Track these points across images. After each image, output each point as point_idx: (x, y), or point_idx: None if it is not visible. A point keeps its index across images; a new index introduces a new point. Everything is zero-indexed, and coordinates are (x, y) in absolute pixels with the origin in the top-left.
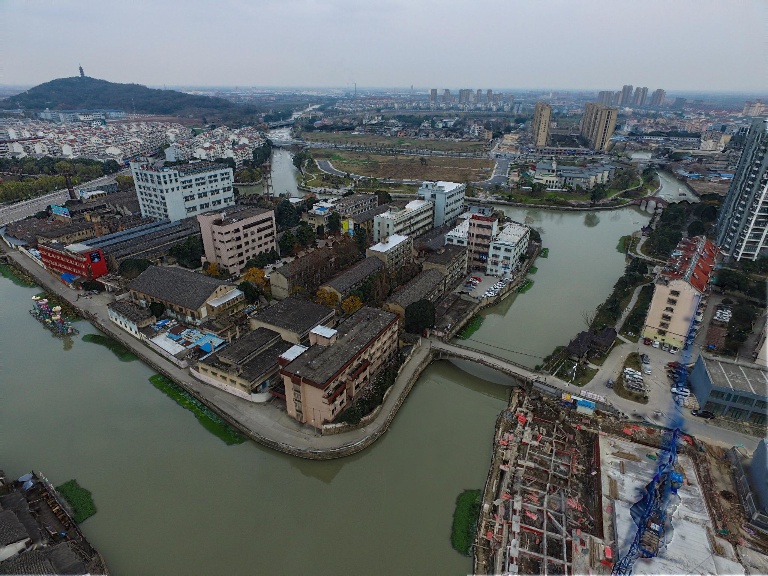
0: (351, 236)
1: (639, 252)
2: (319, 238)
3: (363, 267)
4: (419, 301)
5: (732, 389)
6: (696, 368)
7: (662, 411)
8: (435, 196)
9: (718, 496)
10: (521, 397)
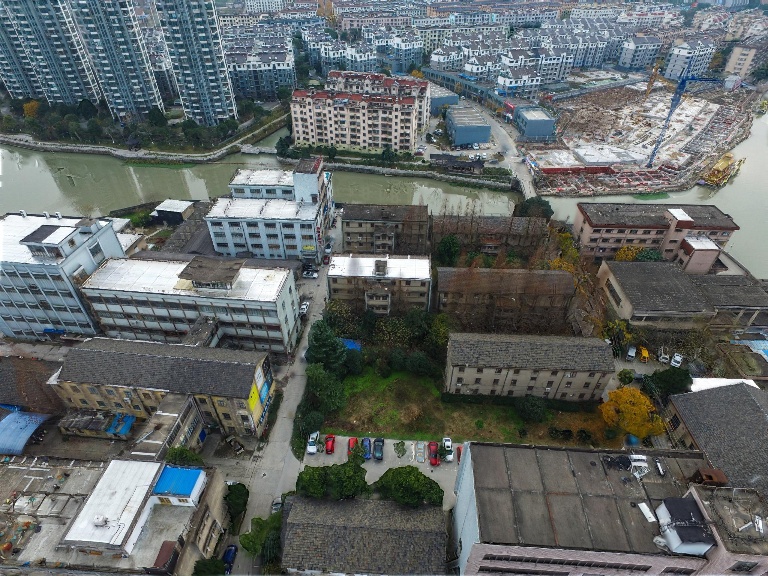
0: (266, 399)
1: (202, 154)
2: (238, 521)
3: (485, 271)
4: (539, 200)
5: (486, 124)
6: (462, 134)
7: (503, 151)
8: (98, 247)
9: (550, 146)
10: (539, 191)
